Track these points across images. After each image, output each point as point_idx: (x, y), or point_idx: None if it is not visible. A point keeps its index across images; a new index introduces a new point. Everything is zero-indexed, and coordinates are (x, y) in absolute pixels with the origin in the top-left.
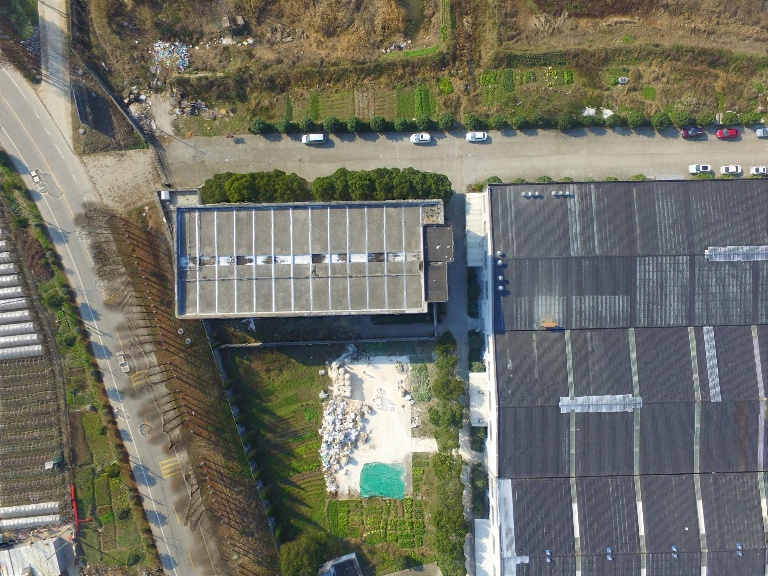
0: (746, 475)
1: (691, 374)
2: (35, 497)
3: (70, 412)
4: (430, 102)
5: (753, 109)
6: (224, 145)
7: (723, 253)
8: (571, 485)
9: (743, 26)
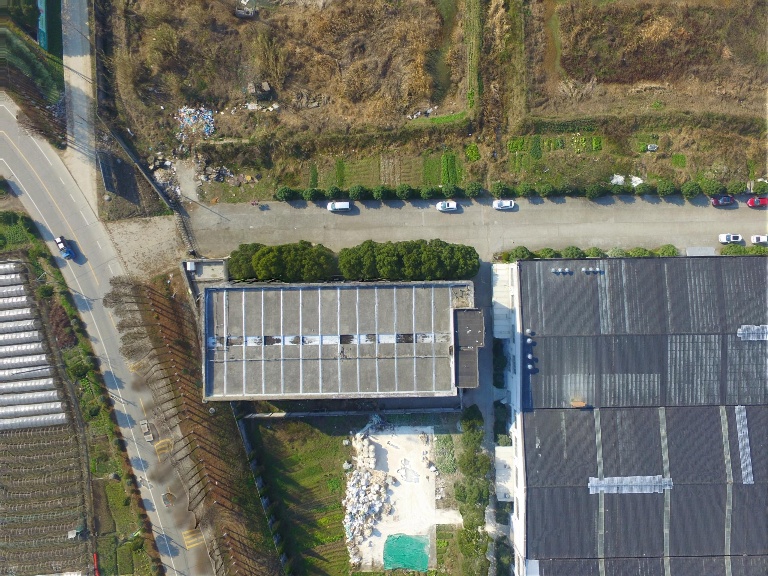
0: None
1: (723, 455)
2: (58, 566)
3: (93, 480)
4: (456, 169)
5: None
6: (249, 212)
7: (756, 332)
8: (599, 566)
9: None
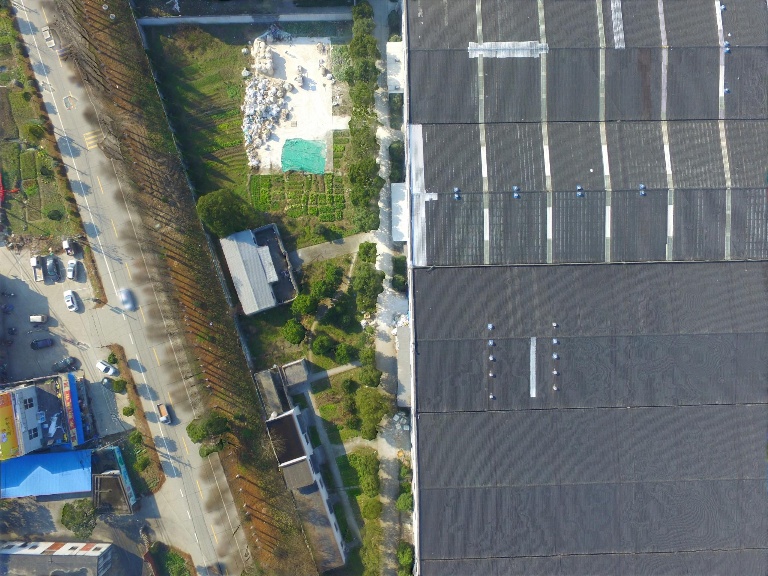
0: (650, 123)
1: (596, 24)
2: None
3: None
4: None
5: None
6: None
7: None
8: (480, 130)
9: None
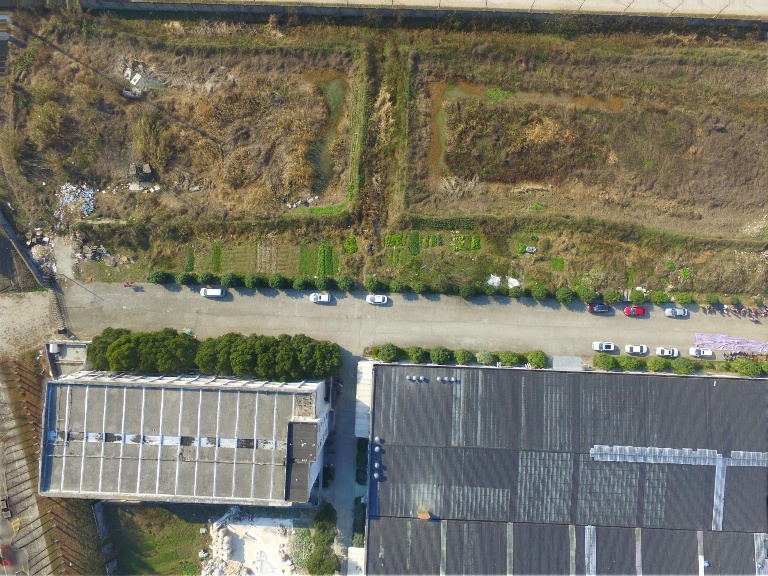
0: None
1: (568, 575)
2: None
3: None
4: (333, 260)
5: (663, 287)
6: (123, 292)
7: (609, 453)
8: None
9: (659, 200)
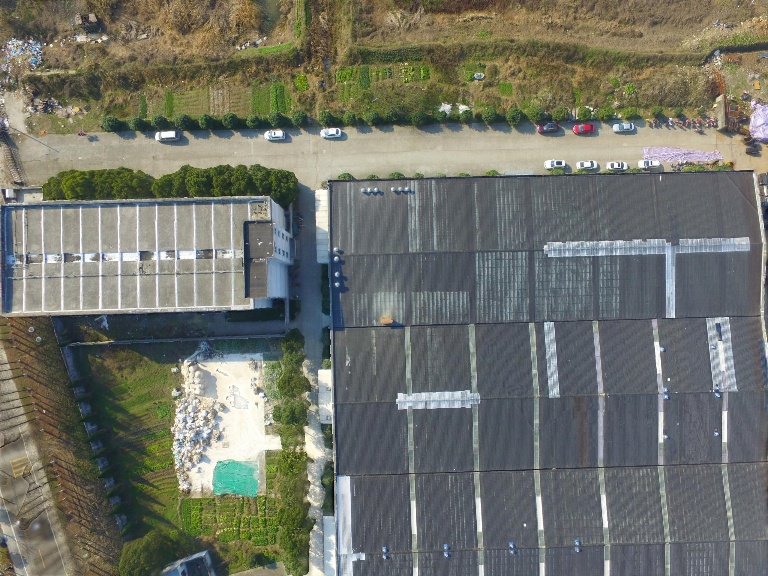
0: (587, 471)
1: (530, 370)
2: None
3: None
4: (285, 99)
5: (610, 104)
6: (78, 143)
7: (562, 248)
8: (410, 482)
9: (601, 21)
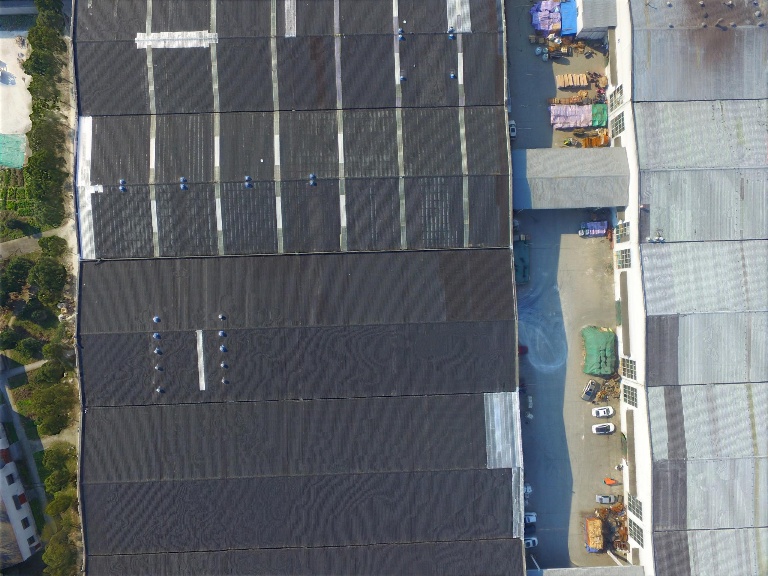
0: (326, 113)
1: (269, 13)
2: None
3: None
4: None
5: None
6: None
7: None
8: (151, 122)
9: None
